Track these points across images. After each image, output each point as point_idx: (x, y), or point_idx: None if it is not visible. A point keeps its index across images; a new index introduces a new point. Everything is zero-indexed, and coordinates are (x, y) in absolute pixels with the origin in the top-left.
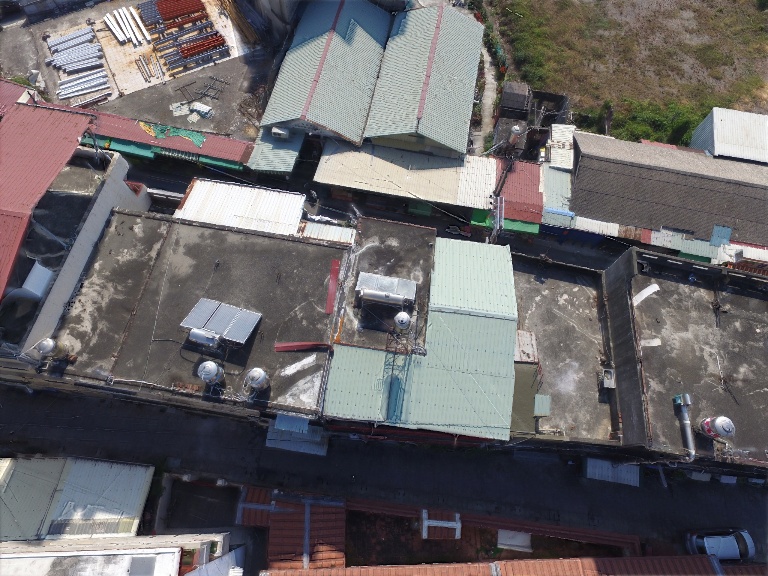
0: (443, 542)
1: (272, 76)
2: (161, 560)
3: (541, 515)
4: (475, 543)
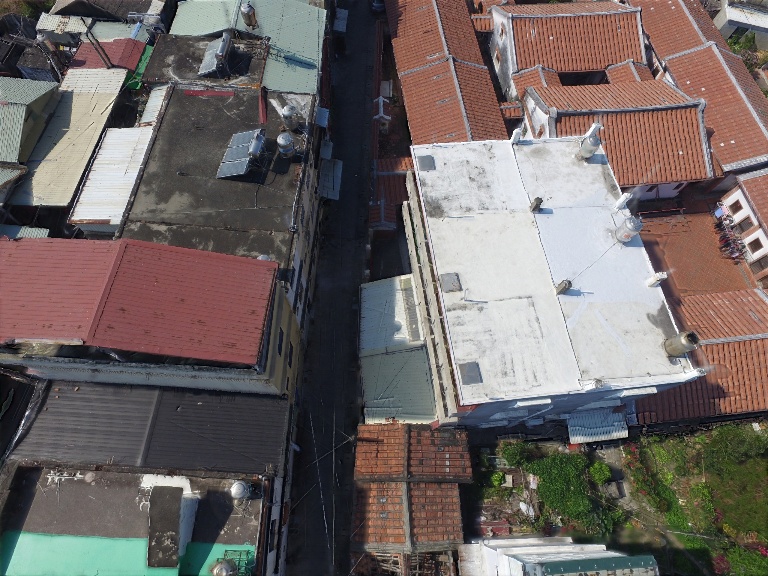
0: (393, 123)
1: None
2: (419, 155)
3: (370, 74)
4: (391, 108)
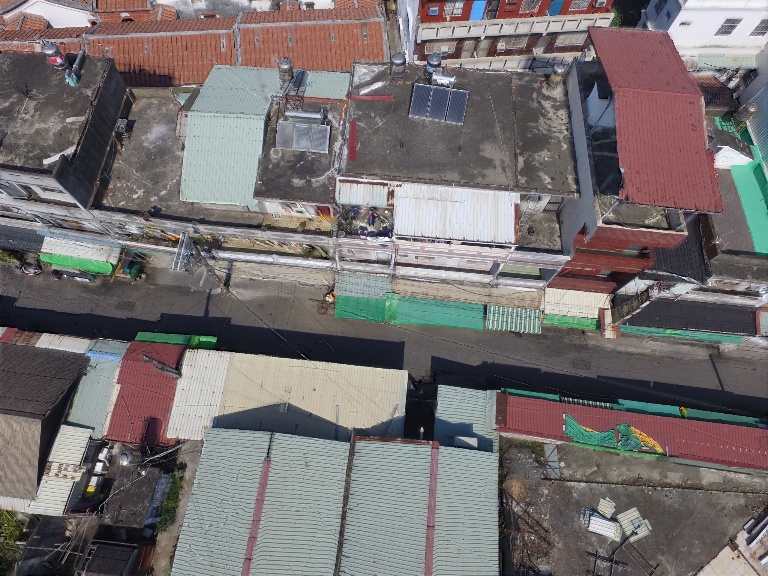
0: None
1: (510, 573)
2: None
3: None
4: None
